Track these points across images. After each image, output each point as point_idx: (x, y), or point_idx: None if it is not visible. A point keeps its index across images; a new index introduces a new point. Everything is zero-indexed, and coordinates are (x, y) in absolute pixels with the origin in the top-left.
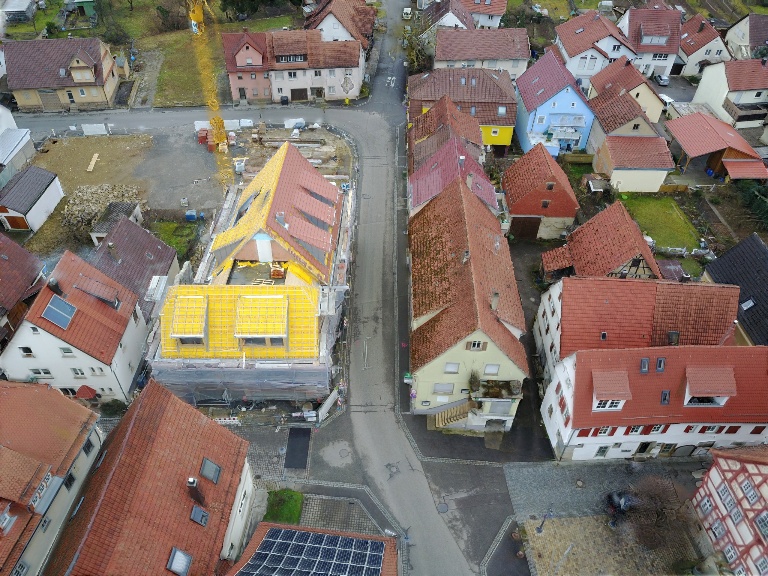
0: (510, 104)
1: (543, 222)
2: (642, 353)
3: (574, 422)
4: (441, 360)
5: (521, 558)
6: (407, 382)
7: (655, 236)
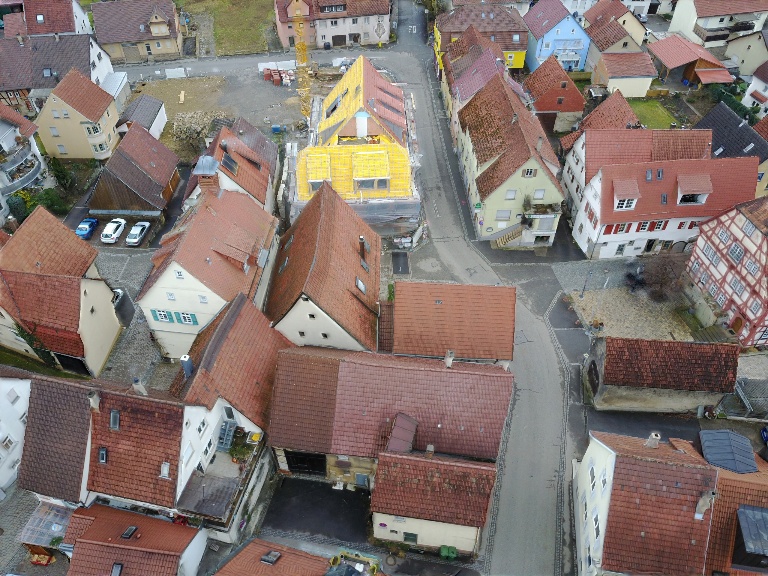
0: (522, 32)
1: (558, 117)
2: (646, 166)
3: (602, 219)
4: (503, 188)
5: (571, 310)
6: (476, 212)
7: None
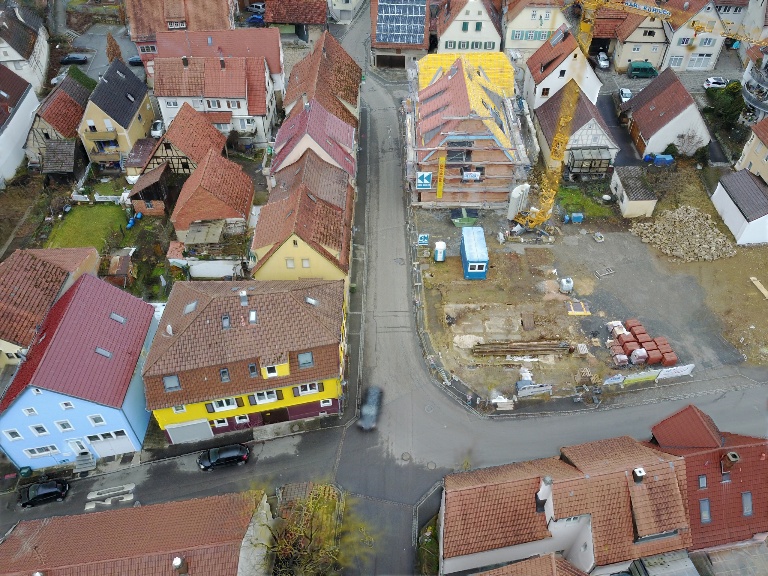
0: None
1: None
2: None
3: None
4: None
5: None
6: (364, 83)
7: (104, 221)
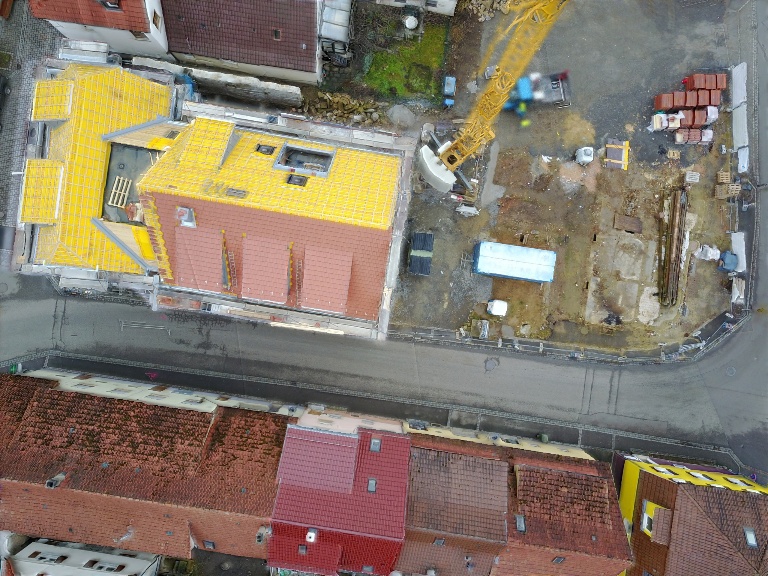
0: None
1: None
2: None
3: None
4: None
5: None
6: None
7: None
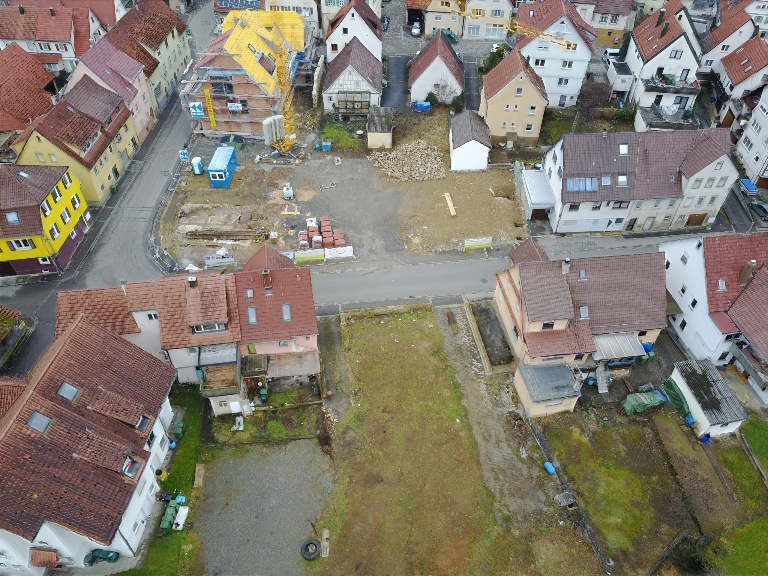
0: None
1: None
2: None
3: (125, 11)
4: None
5: None
6: (190, 38)
7: None
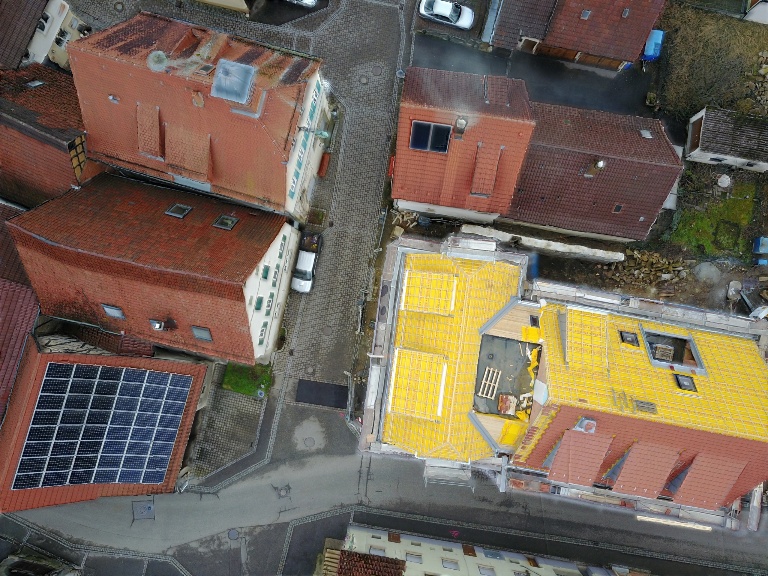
0: None
1: None
2: None
3: None
4: None
5: None
6: None
7: None
